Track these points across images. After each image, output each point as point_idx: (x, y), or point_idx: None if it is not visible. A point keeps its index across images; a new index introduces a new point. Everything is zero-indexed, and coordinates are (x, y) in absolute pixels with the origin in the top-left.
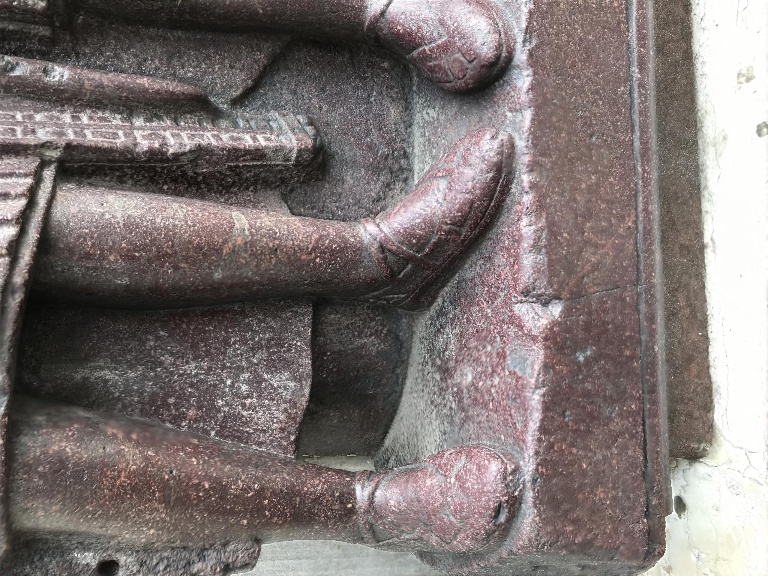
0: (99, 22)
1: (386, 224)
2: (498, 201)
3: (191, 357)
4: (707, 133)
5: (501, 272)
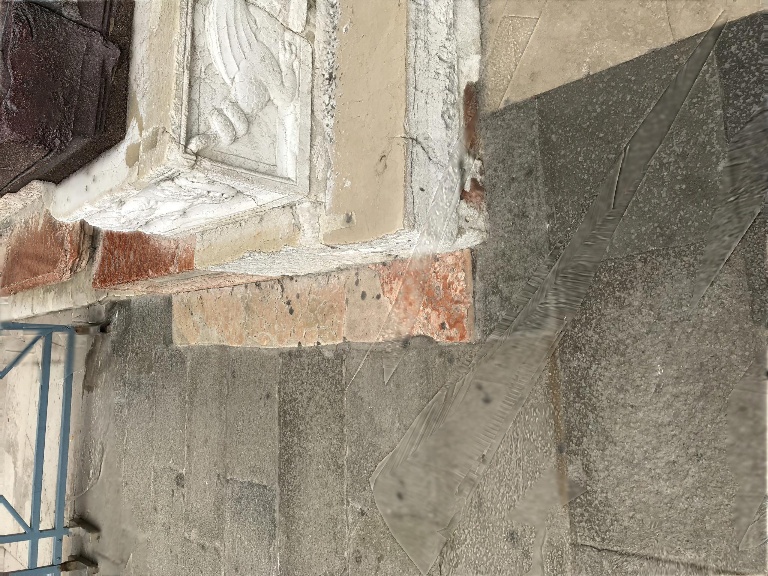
0: None
1: None
2: None
3: None
4: (89, 166)
5: None
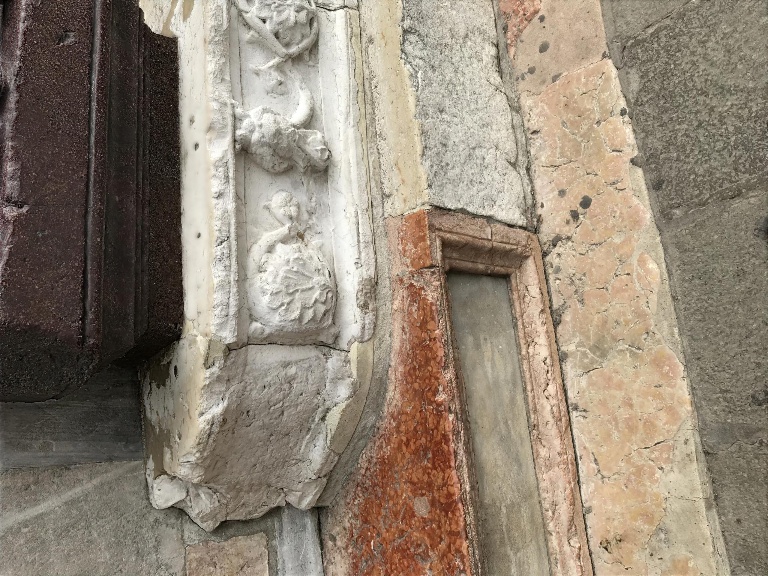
0: None
1: None
2: None
3: None
4: (182, 153)
5: None
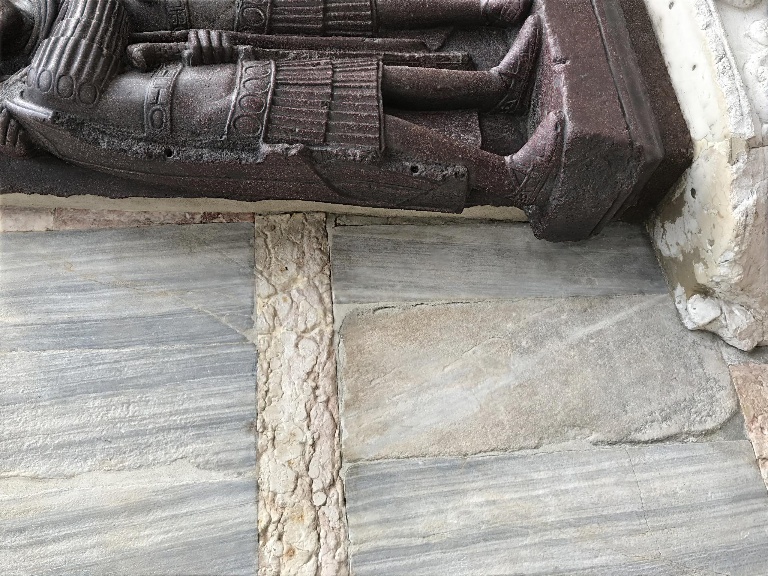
0: (385, 31)
1: (500, 65)
2: (539, 38)
3: (432, 127)
4: (655, 23)
5: (546, 63)
